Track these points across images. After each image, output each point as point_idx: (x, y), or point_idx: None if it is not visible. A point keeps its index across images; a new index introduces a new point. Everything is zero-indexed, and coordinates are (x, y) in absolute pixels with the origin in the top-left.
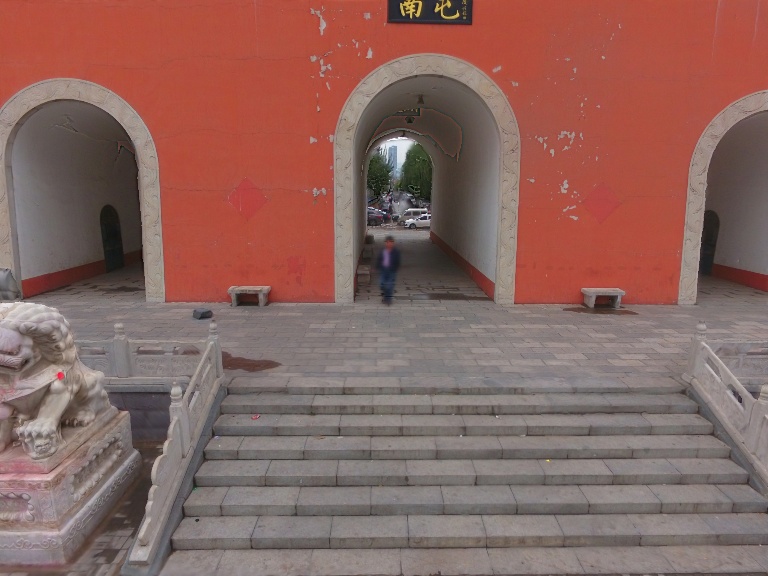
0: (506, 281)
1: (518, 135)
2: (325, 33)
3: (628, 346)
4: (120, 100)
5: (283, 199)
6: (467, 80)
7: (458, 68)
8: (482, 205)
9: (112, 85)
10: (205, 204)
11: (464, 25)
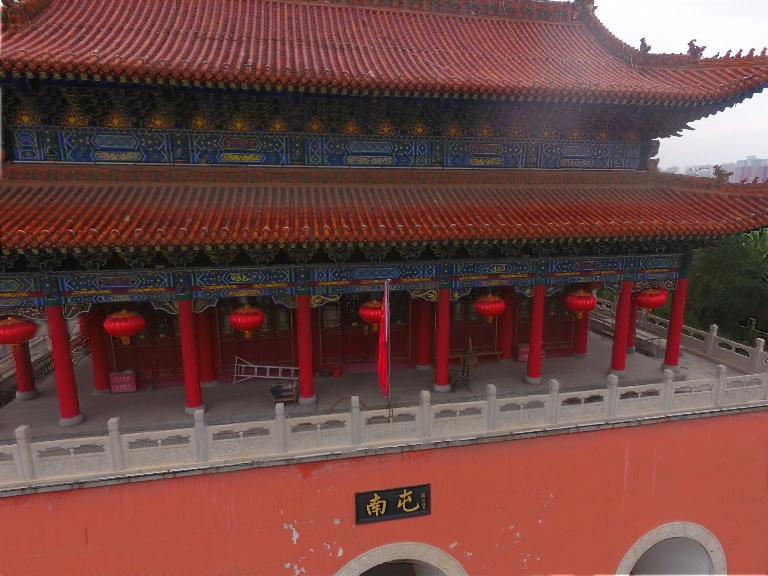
0: None
1: None
2: (298, 542)
3: None
4: None
5: None
6: (429, 559)
7: (420, 551)
8: None
9: None
10: None
11: (424, 516)
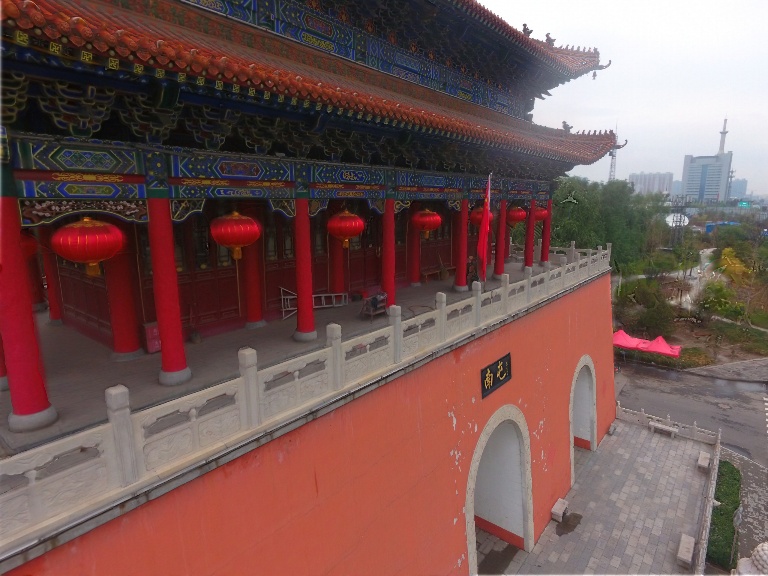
0: (531, 534)
1: (529, 437)
2: (456, 427)
3: (637, 567)
4: None
5: None
6: (512, 416)
7: None
8: None
9: None
10: None
11: (509, 380)
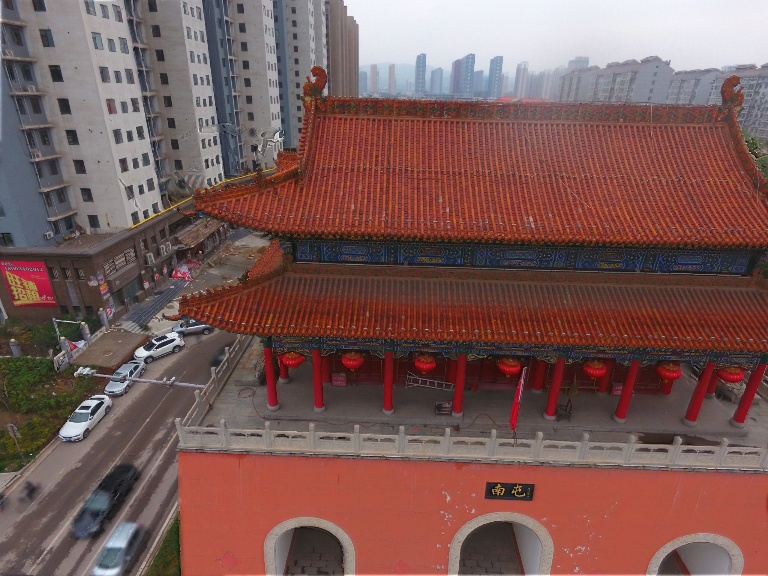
0: None
1: (553, 548)
2: (449, 502)
3: None
4: (336, 527)
5: (420, 569)
6: (527, 524)
7: (522, 519)
8: (528, 538)
9: (332, 520)
10: (378, 570)
11: (528, 500)
